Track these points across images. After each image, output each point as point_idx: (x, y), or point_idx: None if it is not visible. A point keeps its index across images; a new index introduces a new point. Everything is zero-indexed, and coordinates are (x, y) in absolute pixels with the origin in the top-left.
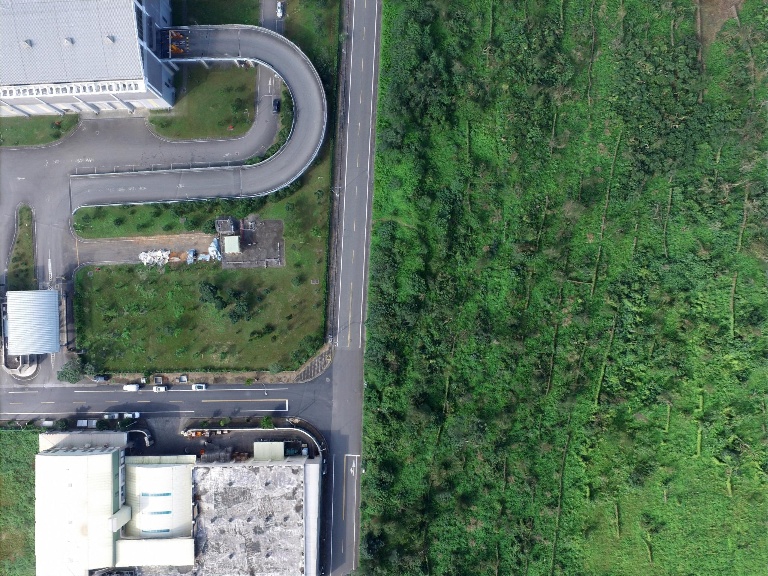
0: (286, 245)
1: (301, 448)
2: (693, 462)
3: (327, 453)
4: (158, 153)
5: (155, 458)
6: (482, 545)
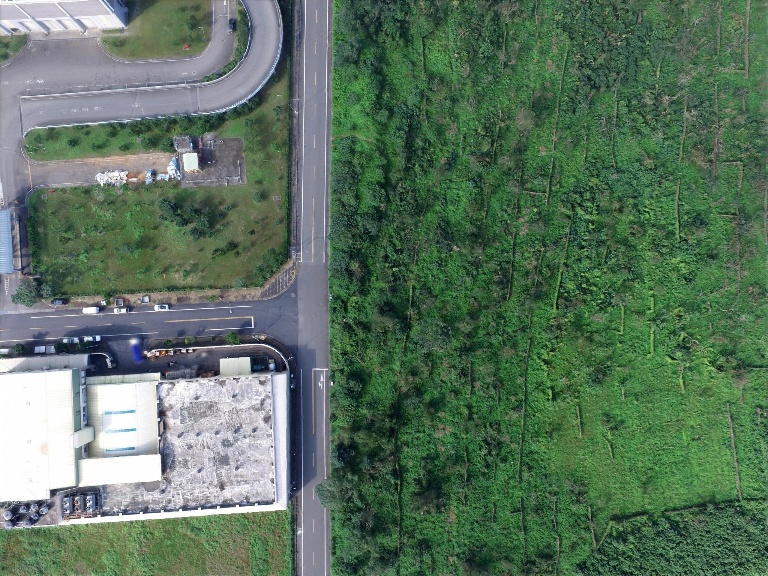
0: (246, 163)
1: (268, 363)
2: (647, 361)
3: (295, 368)
4: (112, 73)
5: (118, 377)
6: (451, 449)
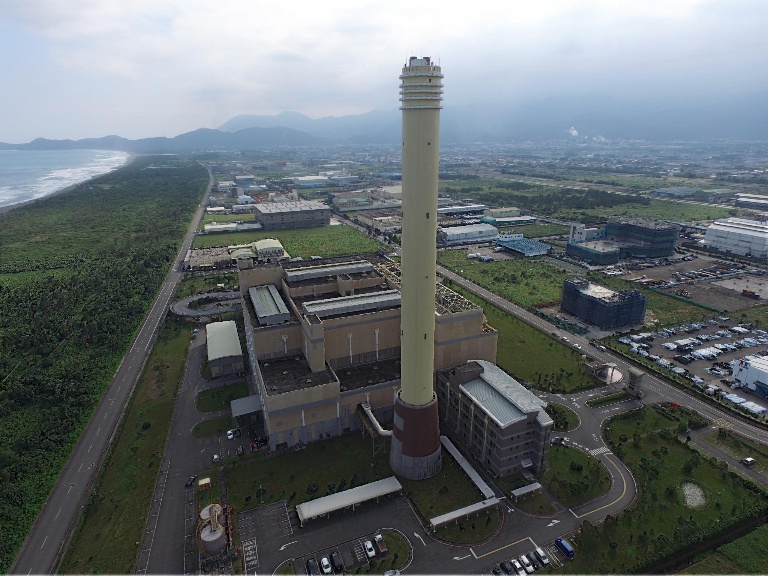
0: None
1: None
2: None
3: None
4: None
5: None
6: None
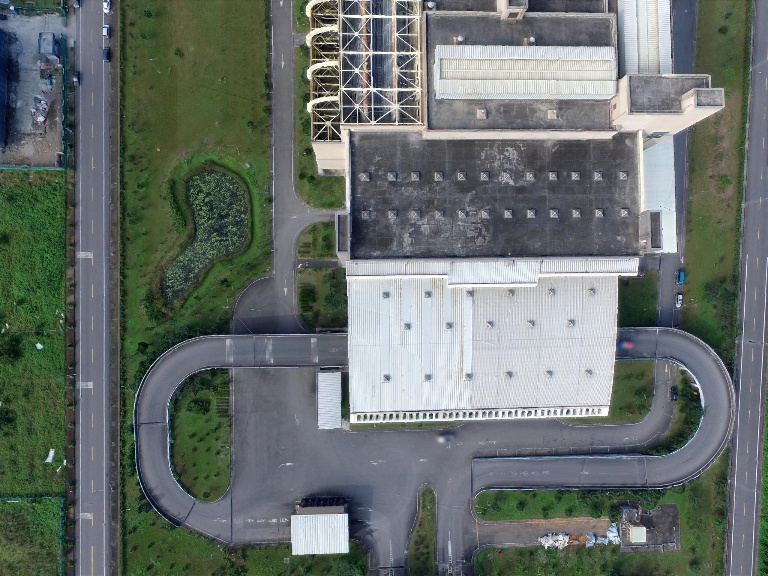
0: (681, 529)
1: None
2: None
3: None
4: (559, 437)
5: None
6: None
